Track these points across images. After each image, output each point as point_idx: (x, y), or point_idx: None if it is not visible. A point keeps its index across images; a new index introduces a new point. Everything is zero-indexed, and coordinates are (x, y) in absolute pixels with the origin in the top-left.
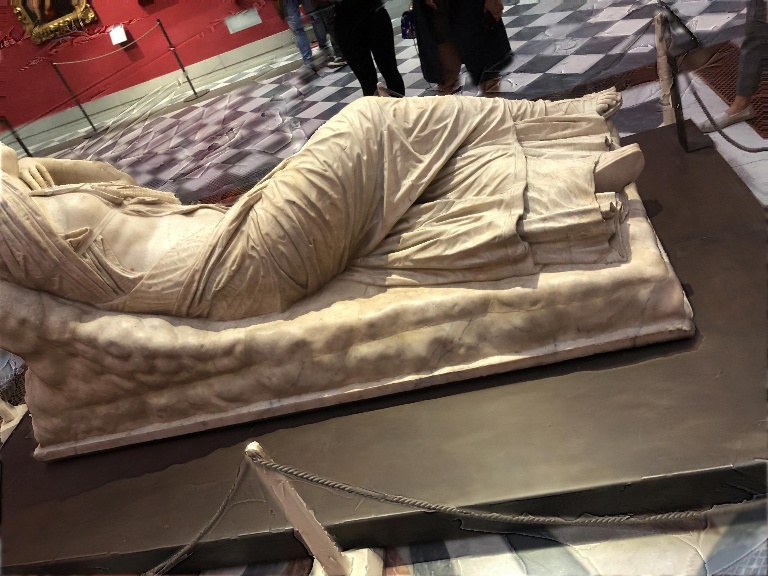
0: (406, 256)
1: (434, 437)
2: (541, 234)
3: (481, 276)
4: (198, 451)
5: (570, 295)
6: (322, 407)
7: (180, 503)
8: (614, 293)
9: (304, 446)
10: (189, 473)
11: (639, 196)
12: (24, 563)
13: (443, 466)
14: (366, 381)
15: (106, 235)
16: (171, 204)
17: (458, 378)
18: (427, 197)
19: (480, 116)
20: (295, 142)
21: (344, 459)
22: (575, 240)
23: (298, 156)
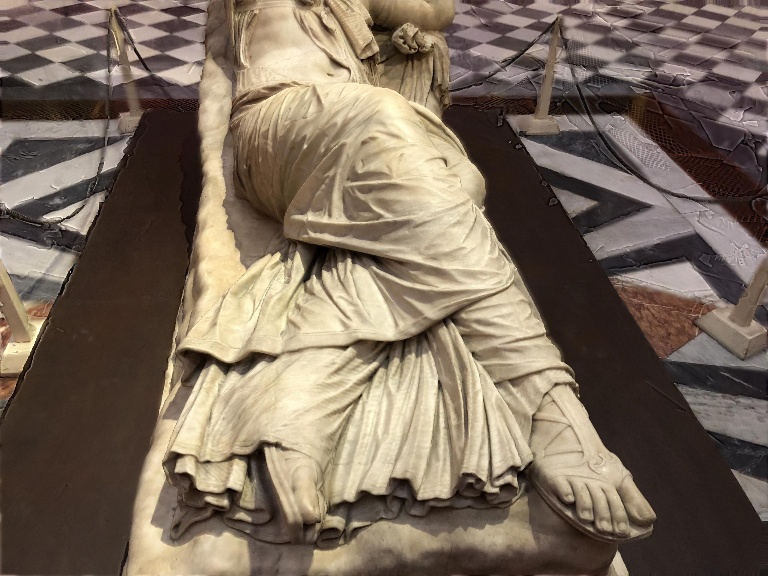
0: None
1: (108, 378)
2: None
3: None
4: (190, 215)
5: None
6: None
7: (138, 218)
8: None
9: (156, 281)
10: (169, 216)
11: (331, 574)
12: (131, 156)
13: (63, 387)
14: None
15: (263, 14)
16: (339, 43)
17: None
18: None
19: (418, 258)
20: (736, 158)
21: (124, 312)
22: None
23: None
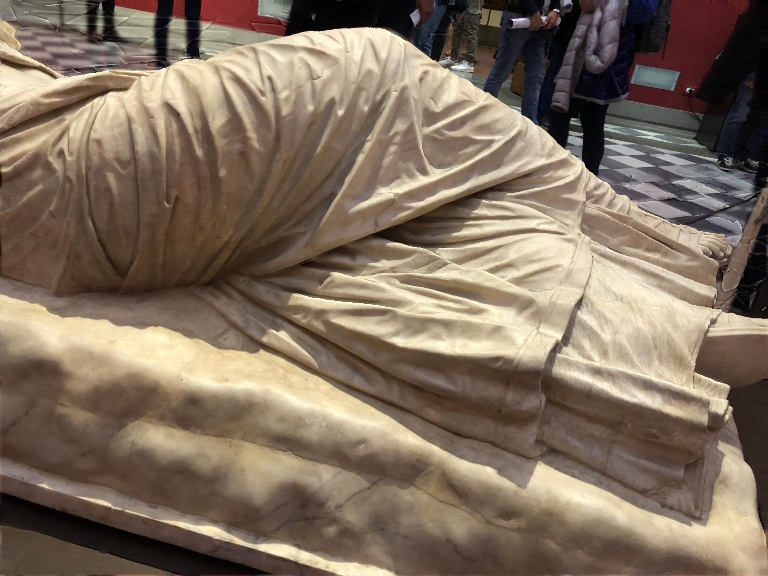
0: (321, 310)
1: None
2: (578, 394)
3: (432, 412)
4: None
5: (580, 534)
6: (28, 500)
7: None
8: (661, 571)
9: None
10: None
11: None
12: None
13: None
14: (132, 494)
15: None
16: None
17: (298, 575)
18: (404, 236)
19: (545, 160)
20: None
21: None
22: (629, 435)
23: (231, 51)
